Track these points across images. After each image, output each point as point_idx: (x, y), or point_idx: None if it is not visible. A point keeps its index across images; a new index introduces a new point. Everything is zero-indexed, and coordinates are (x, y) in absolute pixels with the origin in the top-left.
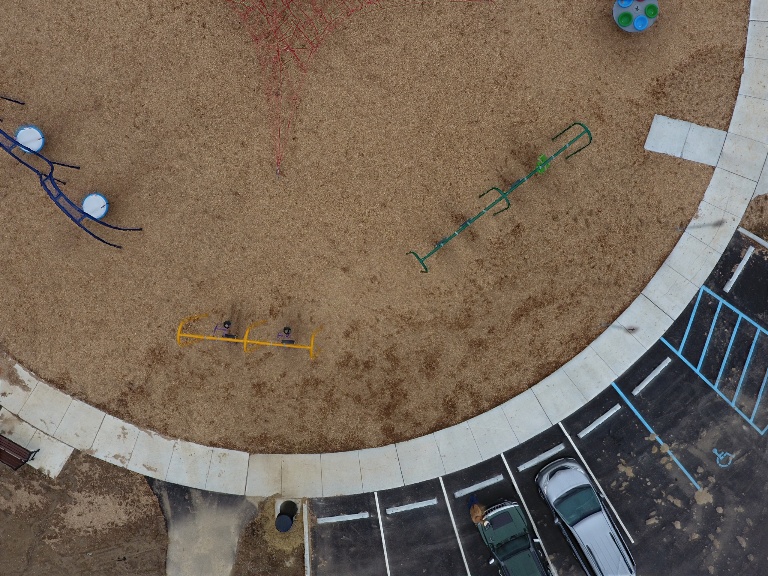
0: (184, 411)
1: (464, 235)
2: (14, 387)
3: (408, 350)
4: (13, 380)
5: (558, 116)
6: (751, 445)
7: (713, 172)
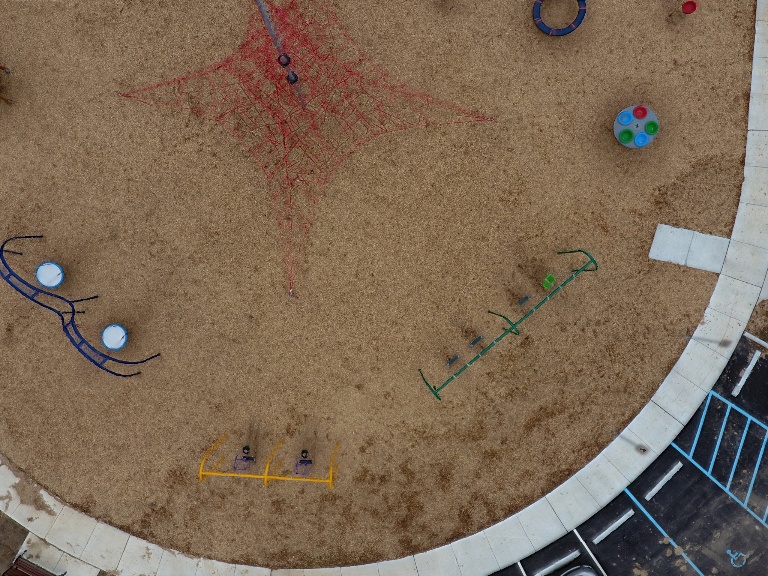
0: (206, 530)
1: (474, 349)
2: (40, 512)
3: (423, 463)
4: (39, 505)
5: (563, 230)
6: (765, 545)
7: (717, 279)
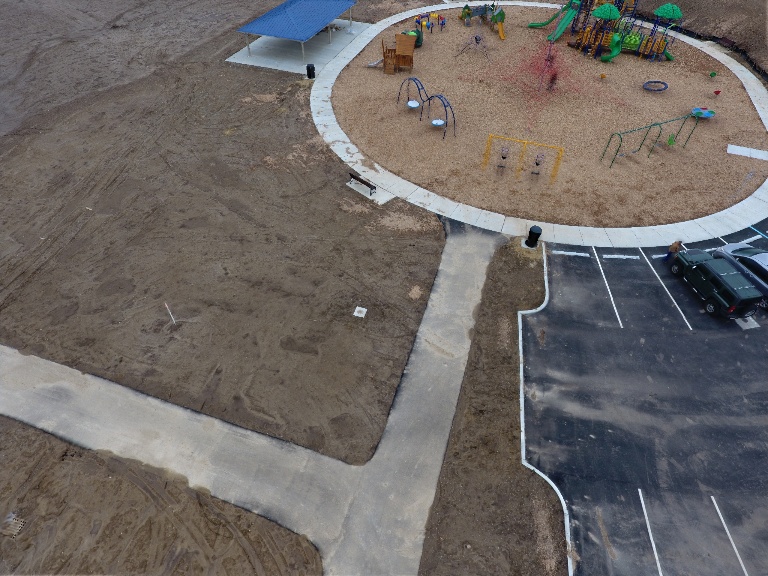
0: (467, 193)
1: None
2: (371, 170)
3: (606, 193)
4: (372, 168)
5: None
6: None
7: None
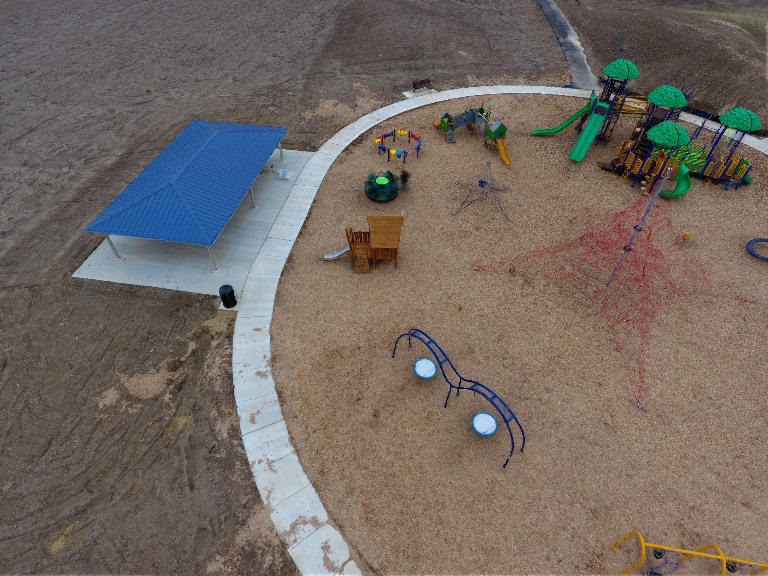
0: None
1: None
2: None
3: None
4: None
5: None
6: None
7: None
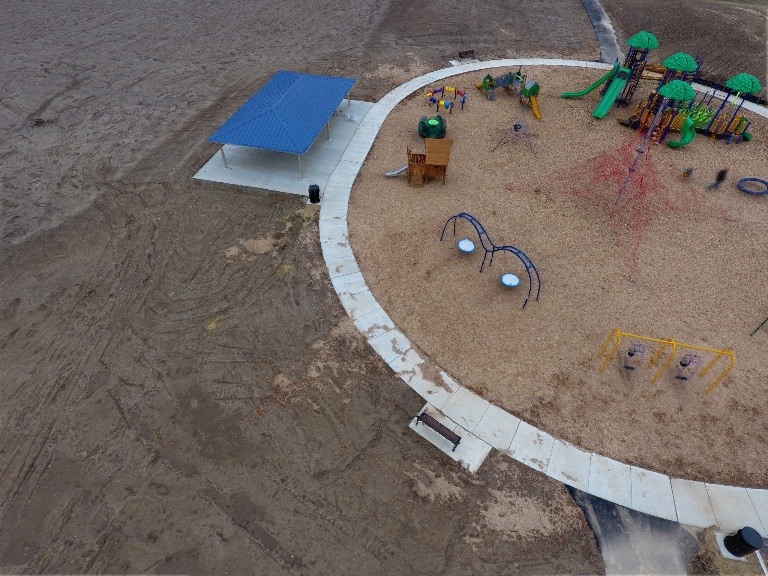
0: (594, 428)
1: None
2: (439, 388)
3: None
4: (439, 382)
5: None
6: None
7: None
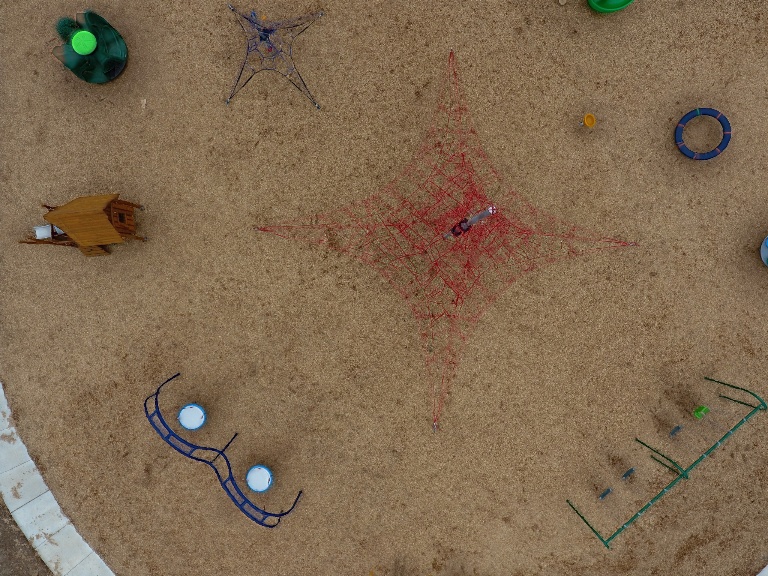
0: None
1: None
2: None
3: None
4: None
5: (709, 353)
6: None
7: None
